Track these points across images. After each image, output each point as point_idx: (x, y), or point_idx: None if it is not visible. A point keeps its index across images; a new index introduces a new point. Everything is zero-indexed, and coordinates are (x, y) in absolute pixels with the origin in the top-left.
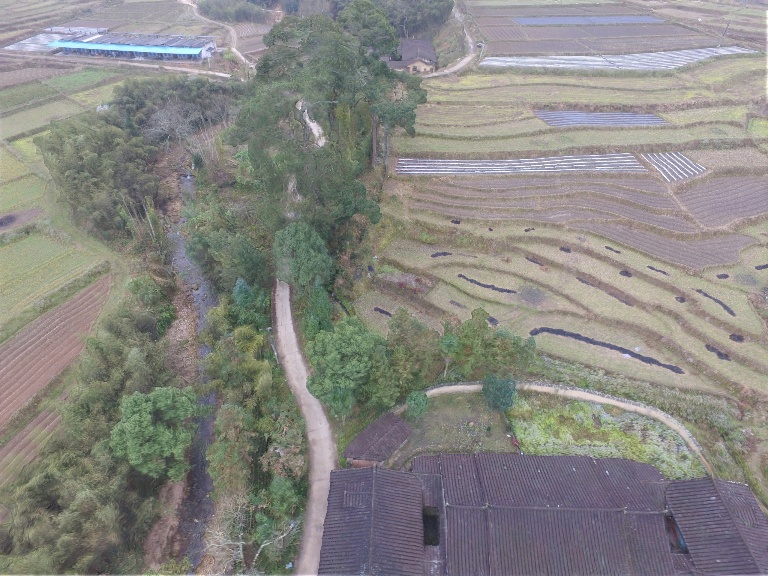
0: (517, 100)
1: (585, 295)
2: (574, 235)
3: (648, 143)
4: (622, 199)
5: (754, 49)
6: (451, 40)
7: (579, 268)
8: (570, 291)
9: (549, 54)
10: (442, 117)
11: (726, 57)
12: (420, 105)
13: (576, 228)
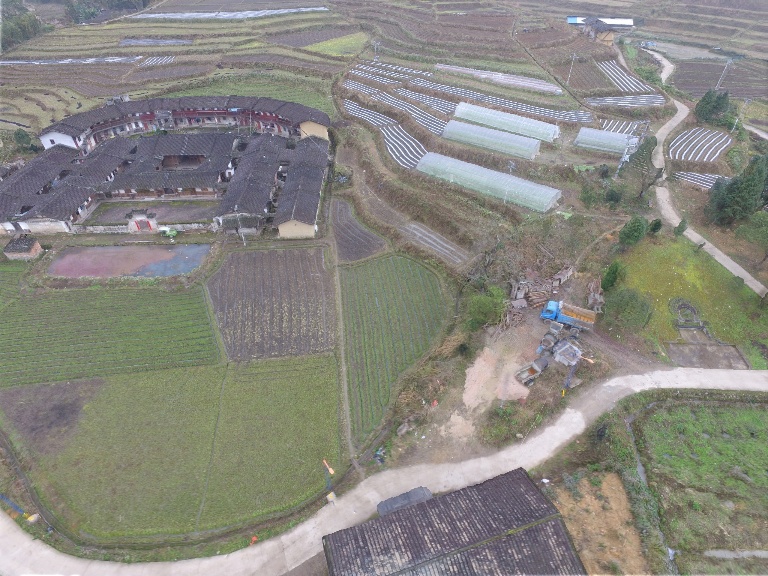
0: (119, 34)
1: (28, 108)
2: (58, 88)
3: (158, 51)
4: (101, 73)
5: (329, 8)
6: (147, 7)
7: (40, 99)
8: (24, 107)
9: (185, 12)
10: (58, 42)
11: (304, 13)
12: (56, 37)
13: (61, 85)
